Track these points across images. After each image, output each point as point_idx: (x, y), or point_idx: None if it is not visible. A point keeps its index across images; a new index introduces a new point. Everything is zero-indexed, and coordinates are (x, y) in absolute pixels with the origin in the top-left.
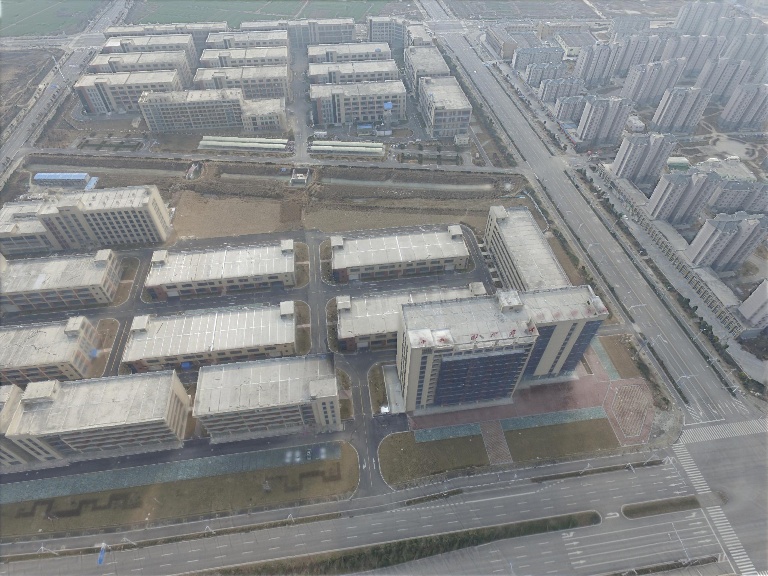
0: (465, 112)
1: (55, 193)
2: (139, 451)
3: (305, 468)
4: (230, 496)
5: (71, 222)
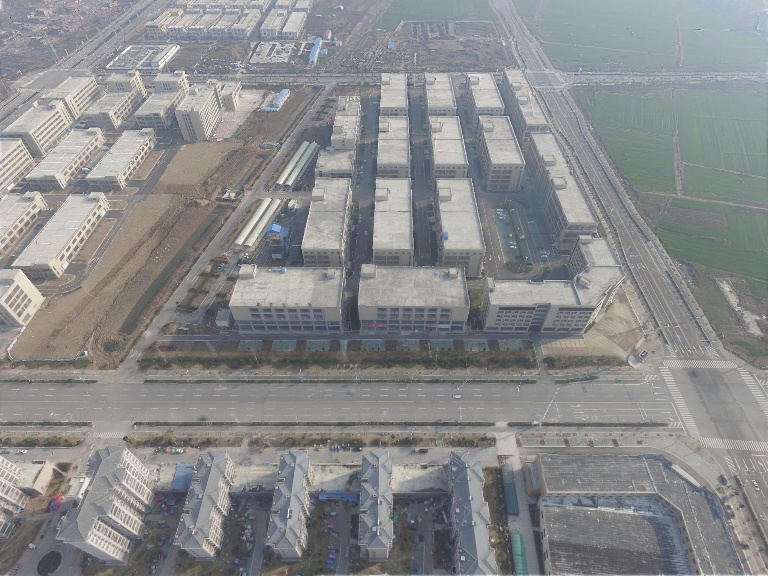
0: None
1: (217, 85)
2: None
3: None
4: None
5: None
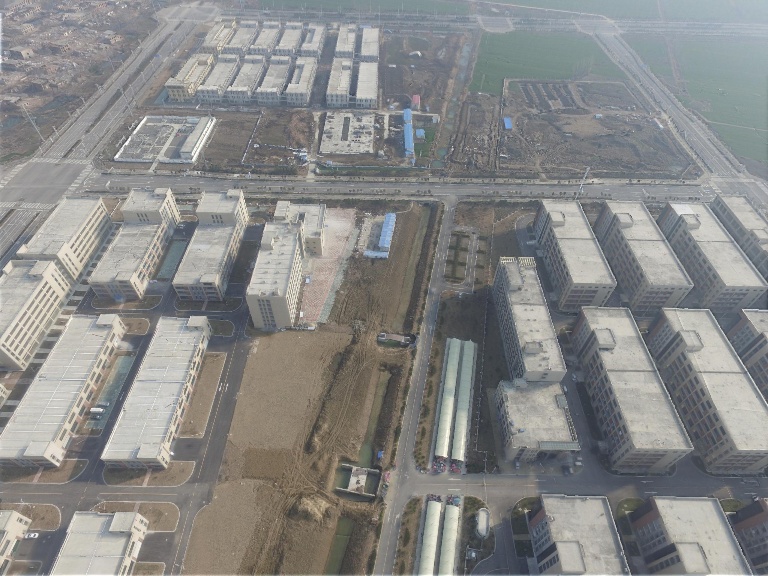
0: None
1: None
2: None
3: None
4: None
5: None
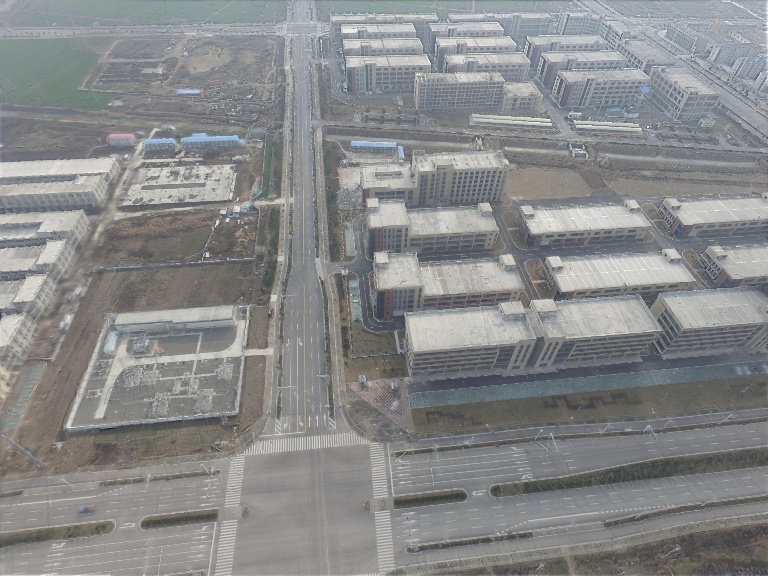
0: (713, 97)
1: (417, 155)
2: (609, 362)
3: (758, 379)
4: (711, 398)
5: (439, 180)
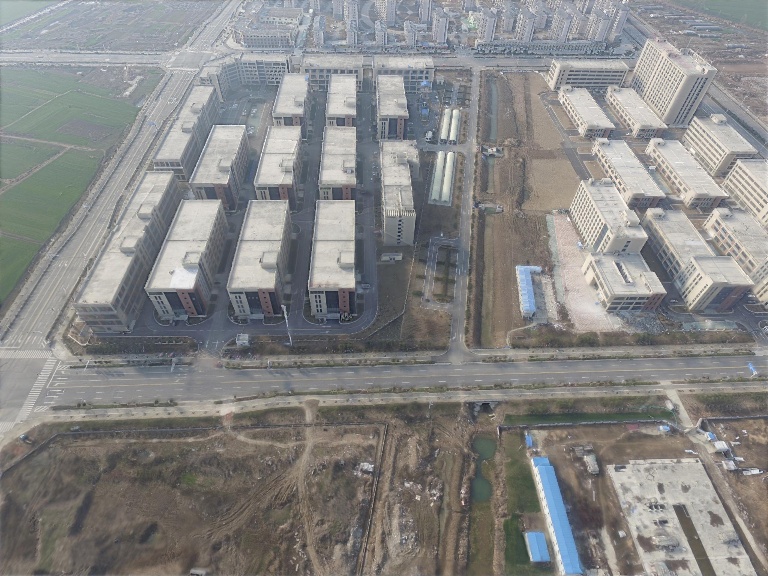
0: None
1: None
2: None
3: None
4: None
5: None
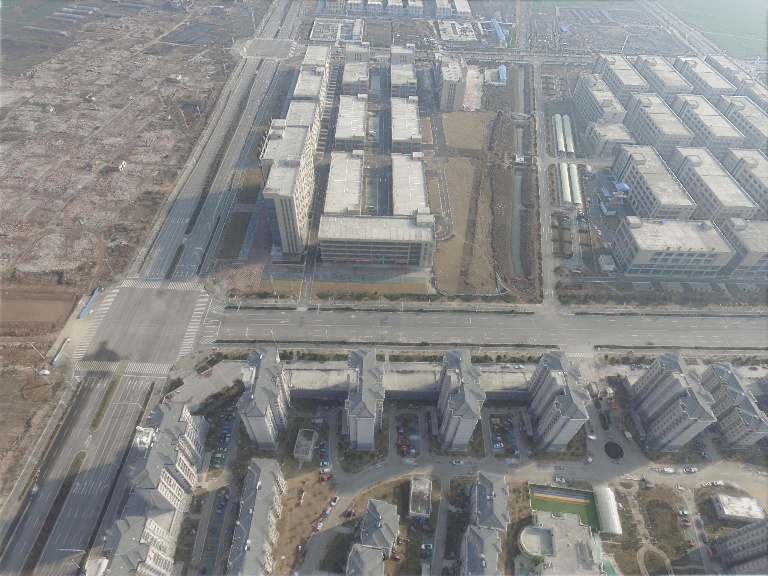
0: None
1: None
2: None
3: None
4: None
5: None
